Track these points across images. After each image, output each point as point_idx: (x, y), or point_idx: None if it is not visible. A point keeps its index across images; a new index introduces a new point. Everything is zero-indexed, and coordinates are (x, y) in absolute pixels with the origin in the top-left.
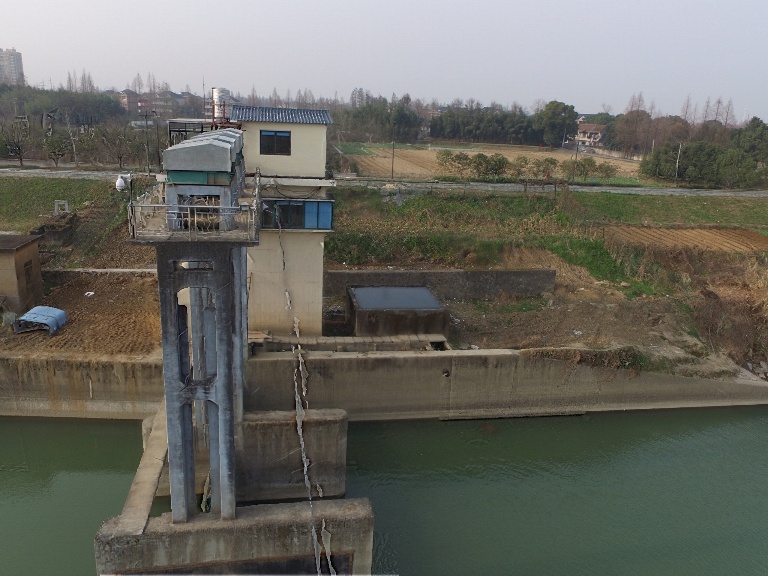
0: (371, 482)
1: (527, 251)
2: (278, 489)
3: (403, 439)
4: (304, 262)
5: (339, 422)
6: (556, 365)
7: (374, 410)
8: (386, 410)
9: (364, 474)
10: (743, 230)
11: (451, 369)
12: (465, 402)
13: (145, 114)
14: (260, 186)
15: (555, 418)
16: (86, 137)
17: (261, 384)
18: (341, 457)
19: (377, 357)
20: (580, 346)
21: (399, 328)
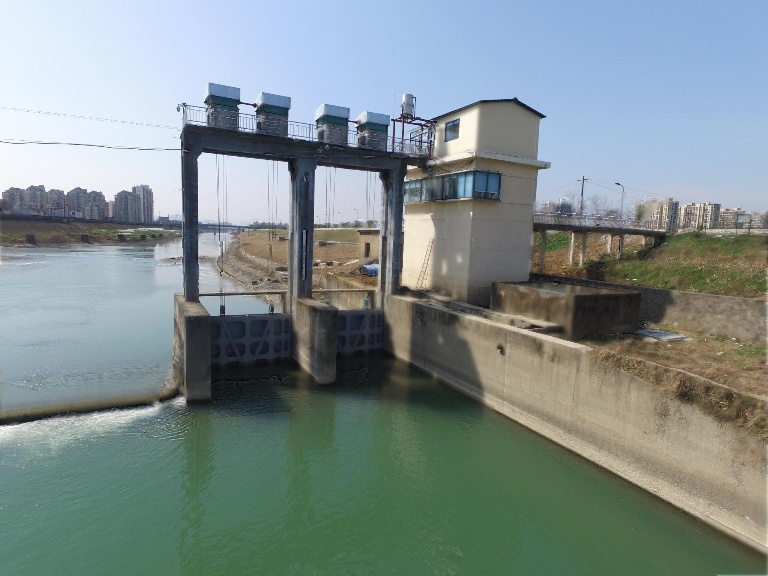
0: (356, 396)
1: None
2: (302, 358)
3: (446, 404)
4: (460, 230)
5: (319, 312)
6: (640, 389)
7: (447, 370)
8: (455, 374)
9: (356, 386)
10: None
11: (506, 346)
12: (519, 398)
13: (583, 179)
14: (388, 152)
15: (641, 492)
16: (578, 211)
17: (394, 317)
18: (320, 345)
19: (452, 313)
20: (767, 400)
21: (523, 308)
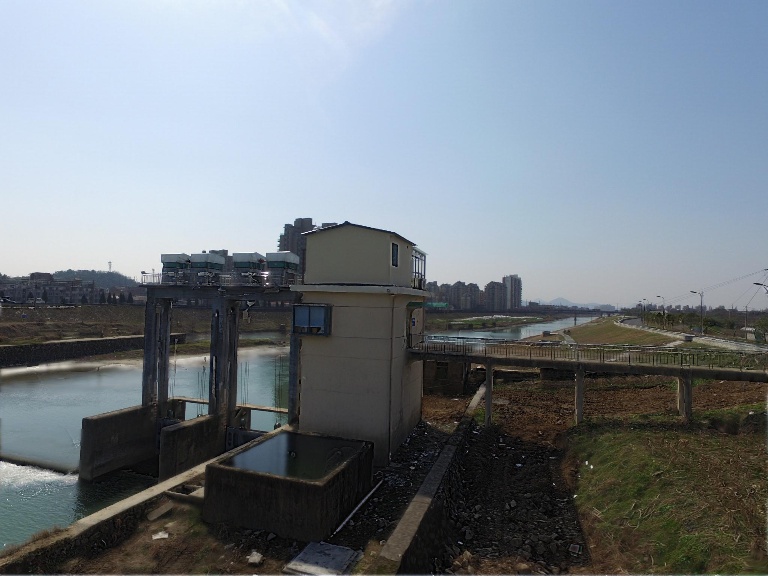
0: None
1: None
2: None
3: None
4: None
5: None
6: None
7: None
8: None
9: None
10: None
11: None
12: None
13: None
14: (274, 286)
15: None
16: None
17: None
18: None
19: None
20: None
21: None
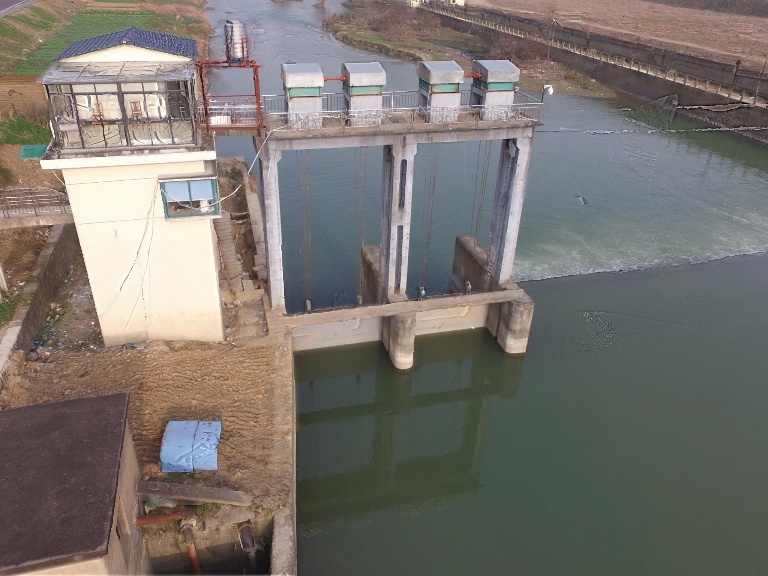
0: None
1: (4, 152)
2: None
3: None
4: None
5: None
6: None
7: None
8: None
9: None
10: (6, 76)
11: None
12: None
13: None
14: None
15: None
16: None
17: None
18: None
19: None
20: (226, 179)
21: None
